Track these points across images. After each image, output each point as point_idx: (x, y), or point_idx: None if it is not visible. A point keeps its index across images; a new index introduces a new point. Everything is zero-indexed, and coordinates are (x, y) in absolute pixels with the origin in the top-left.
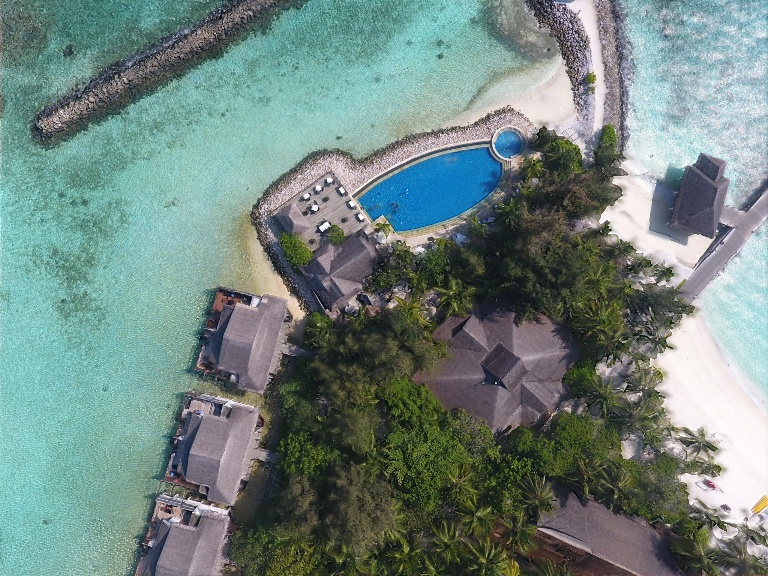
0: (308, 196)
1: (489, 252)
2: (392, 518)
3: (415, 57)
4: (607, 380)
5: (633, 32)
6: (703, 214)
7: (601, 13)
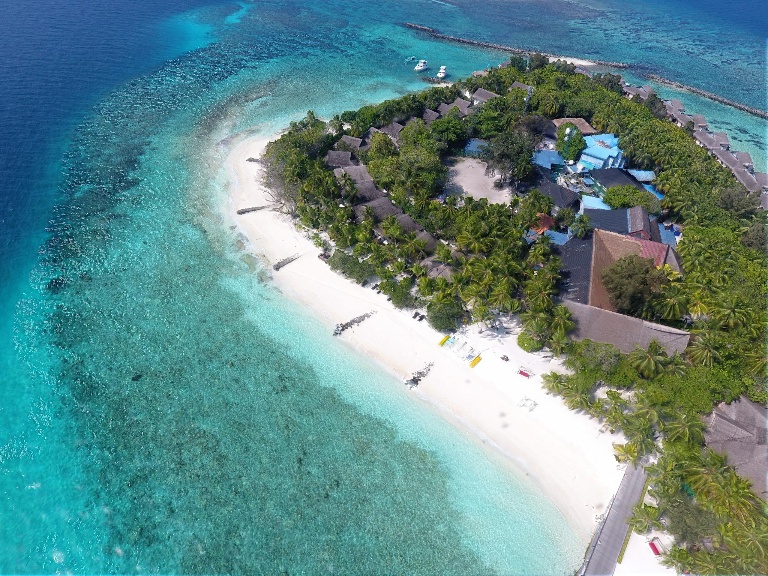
0: None
1: None
2: None
3: None
4: None
5: None
6: None
7: None
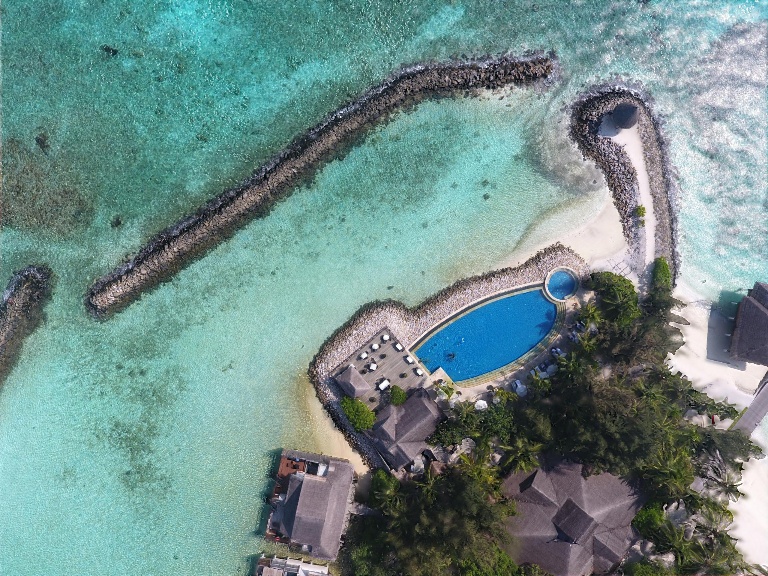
0: (366, 355)
1: (553, 408)
2: None
3: (461, 199)
4: (674, 515)
5: (678, 156)
6: (764, 349)
7: (646, 144)
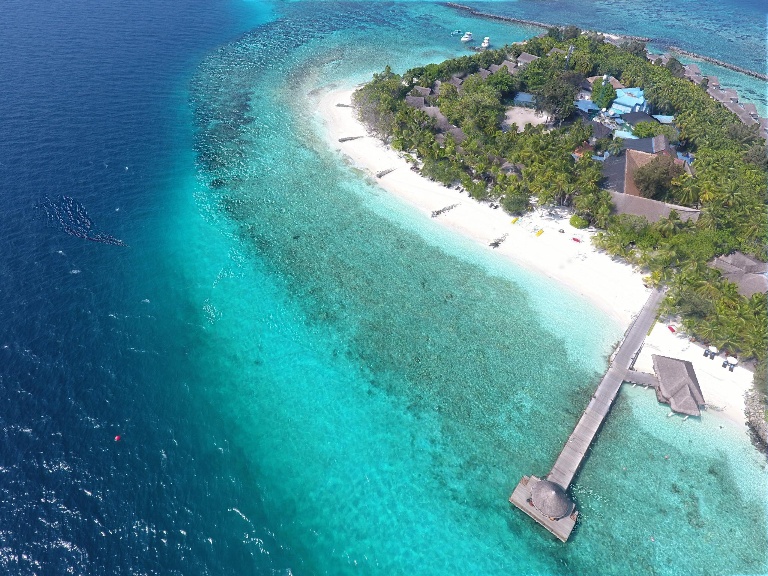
0: None
1: None
2: None
3: None
4: None
5: None
6: None
7: None
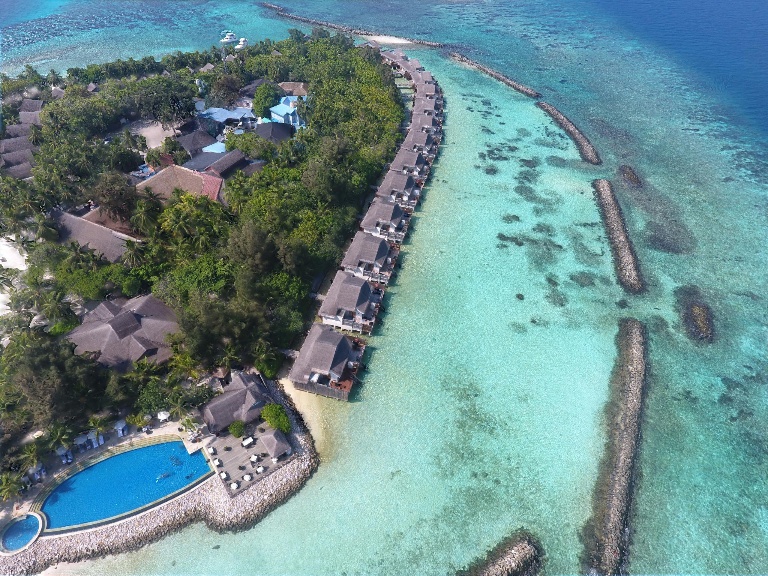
0: (258, 469)
1: None
2: (230, 241)
3: None
4: (44, 330)
5: None
6: None
7: None
